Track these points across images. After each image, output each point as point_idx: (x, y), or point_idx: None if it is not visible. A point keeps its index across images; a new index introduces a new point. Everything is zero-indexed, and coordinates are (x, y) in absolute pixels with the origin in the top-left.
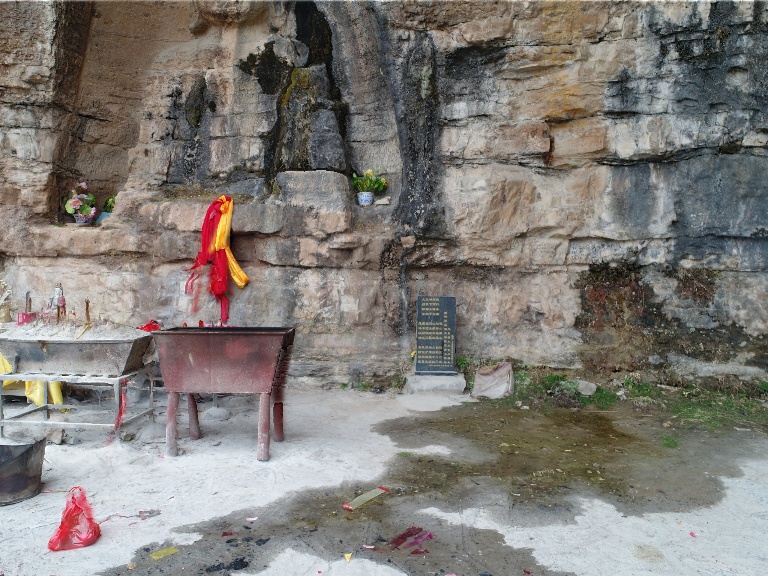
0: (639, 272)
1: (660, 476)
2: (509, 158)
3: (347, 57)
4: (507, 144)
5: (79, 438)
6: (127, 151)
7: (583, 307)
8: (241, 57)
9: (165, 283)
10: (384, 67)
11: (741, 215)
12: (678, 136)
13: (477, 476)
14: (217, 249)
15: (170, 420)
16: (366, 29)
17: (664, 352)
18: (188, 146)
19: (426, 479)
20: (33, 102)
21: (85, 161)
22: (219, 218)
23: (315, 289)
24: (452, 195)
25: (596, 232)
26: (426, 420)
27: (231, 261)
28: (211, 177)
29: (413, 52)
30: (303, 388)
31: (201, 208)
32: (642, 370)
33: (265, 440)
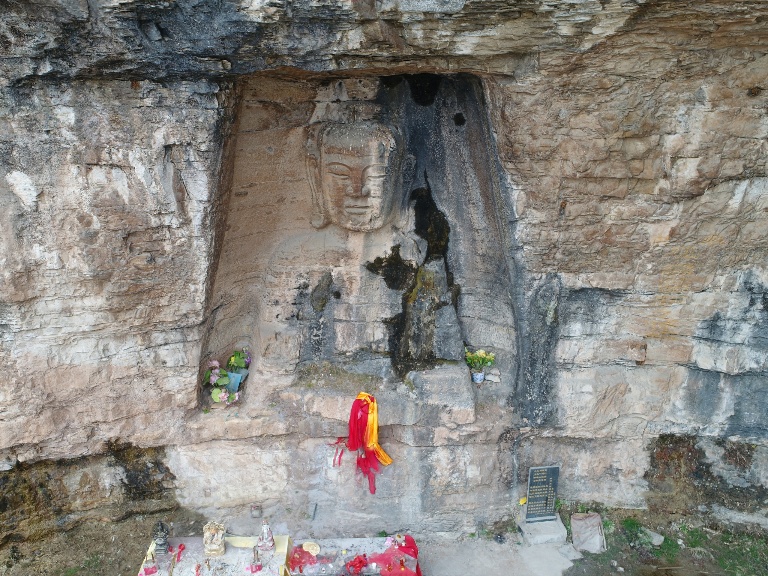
0: (696, 438)
1: None
2: (609, 361)
3: (463, 251)
4: (609, 351)
5: None
6: (244, 316)
7: (652, 464)
8: (368, 259)
9: (313, 457)
10: (514, 295)
11: None
12: (749, 363)
13: None
14: (368, 445)
15: None
16: (489, 241)
17: (710, 504)
18: (313, 327)
19: None
20: (183, 326)
21: (213, 340)
22: (367, 418)
23: (446, 463)
24: (565, 399)
25: (671, 419)
26: None
27: (378, 450)
28: (337, 354)
29: (543, 289)
30: (443, 543)
31: (343, 401)
32: (693, 515)
33: None
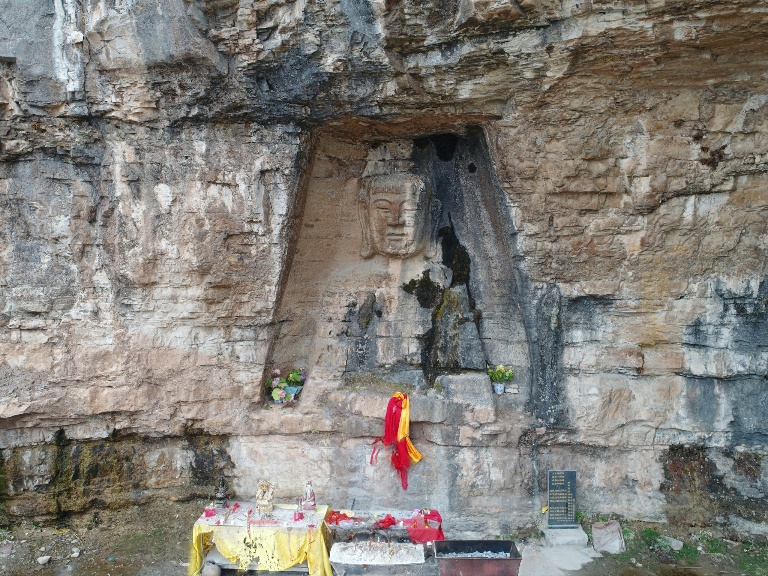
0: (705, 451)
1: None
2: (612, 369)
3: (482, 279)
4: (610, 359)
5: None
6: (303, 338)
7: (666, 476)
8: (404, 281)
9: (353, 455)
10: (522, 304)
11: None
12: (736, 365)
13: None
14: (401, 437)
15: None
16: (501, 265)
17: (727, 514)
18: (359, 342)
19: None
20: (256, 324)
21: (277, 352)
22: (400, 412)
23: (471, 463)
24: (574, 399)
25: (676, 425)
26: None
27: (410, 444)
28: (378, 367)
29: (545, 297)
30: None
31: (381, 400)
32: (711, 527)
33: None
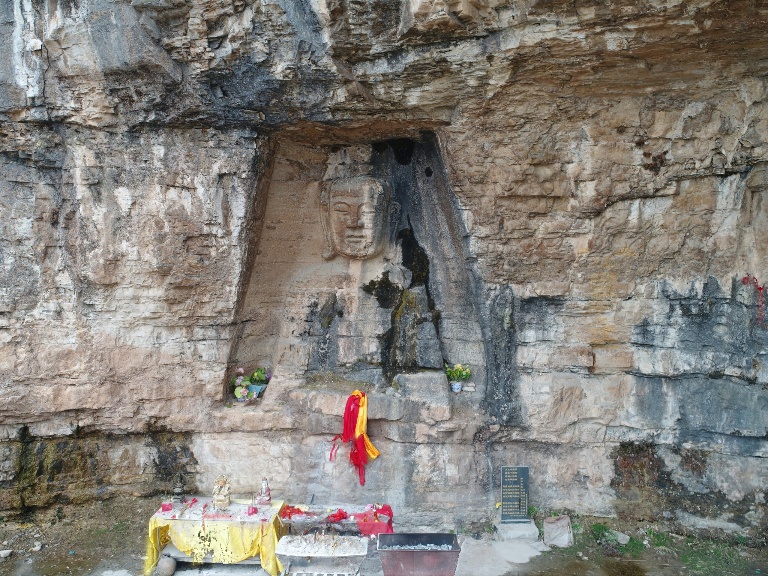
0: (654, 448)
1: None
2: (564, 368)
3: (441, 280)
4: (563, 358)
5: None
6: (267, 337)
7: (616, 472)
8: (364, 282)
9: (313, 452)
10: (476, 305)
11: (724, 420)
12: (682, 365)
13: None
14: (358, 434)
15: None
16: (458, 267)
17: (673, 509)
18: (321, 341)
19: None
20: (218, 324)
21: (241, 351)
22: (358, 410)
23: (427, 460)
24: (526, 397)
25: (625, 423)
26: (525, 575)
27: (367, 441)
28: (339, 366)
29: (498, 298)
30: None
31: (340, 398)
32: (659, 522)
33: None
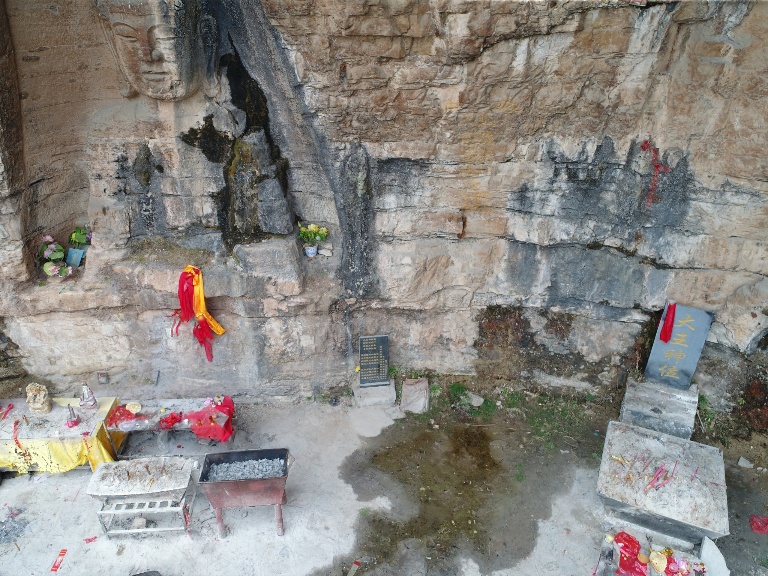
0: (522, 309)
1: (507, 525)
2: (430, 234)
3: (284, 122)
4: (429, 224)
5: (153, 519)
6: (77, 192)
7: (480, 334)
8: (182, 130)
9: (152, 328)
10: (323, 166)
11: (595, 289)
12: (559, 234)
13: (408, 539)
14: (196, 316)
15: (219, 522)
16: None
17: (531, 369)
18: (142, 201)
19: (379, 547)
20: None
21: (44, 215)
22: (193, 290)
23: (279, 333)
24: (385, 270)
25: (493, 290)
26: (372, 453)
27: (209, 321)
28: (170, 229)
29: (349, 159)
30: (279, 405)
31: (172, 273)
32: (516, 380)
33: (281, 526)
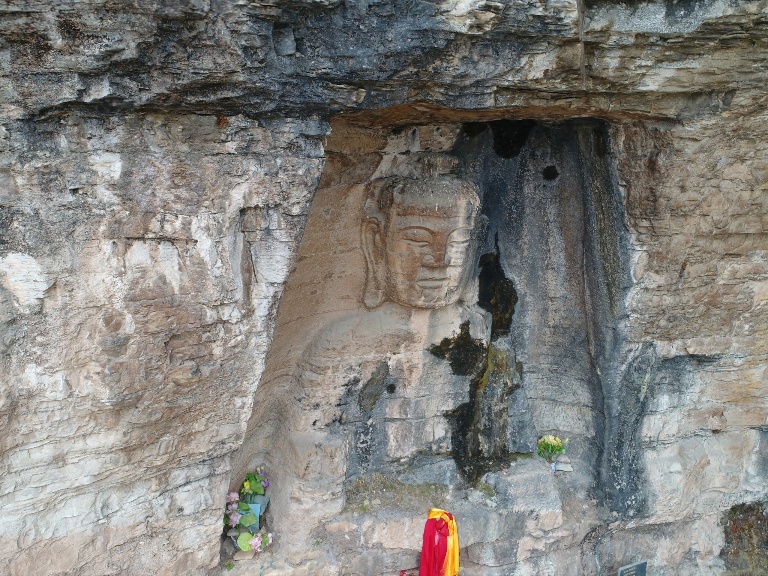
0: (763, 504)
1: None
2: (690, 433)
3: (530, 323)
4: (690, 422)
5: None
6: (262, 427)
7: (726, 540)
8: (434, 342)
9: None
10: (605, 370)
11: None
12: None
13: None
14: None
15: None
16: (566, 310)
17: None
18: (360, 431)
19: None
20: (215, 456)
21: None
22: (446, 542)
23: None
24: (656, 482)
25: (748, 488)
26: None
27: None
28: (389, 462)
29: (638, 361)
30: None
31: (411, 523)
32: None
33: None
